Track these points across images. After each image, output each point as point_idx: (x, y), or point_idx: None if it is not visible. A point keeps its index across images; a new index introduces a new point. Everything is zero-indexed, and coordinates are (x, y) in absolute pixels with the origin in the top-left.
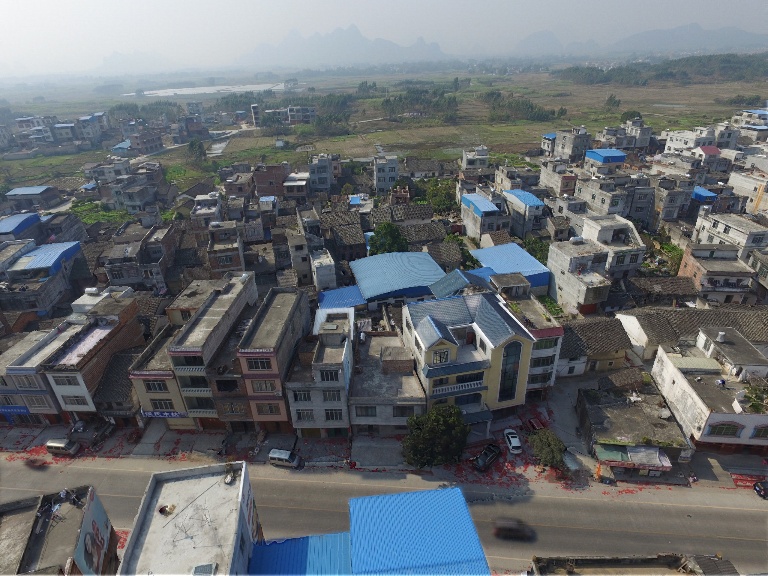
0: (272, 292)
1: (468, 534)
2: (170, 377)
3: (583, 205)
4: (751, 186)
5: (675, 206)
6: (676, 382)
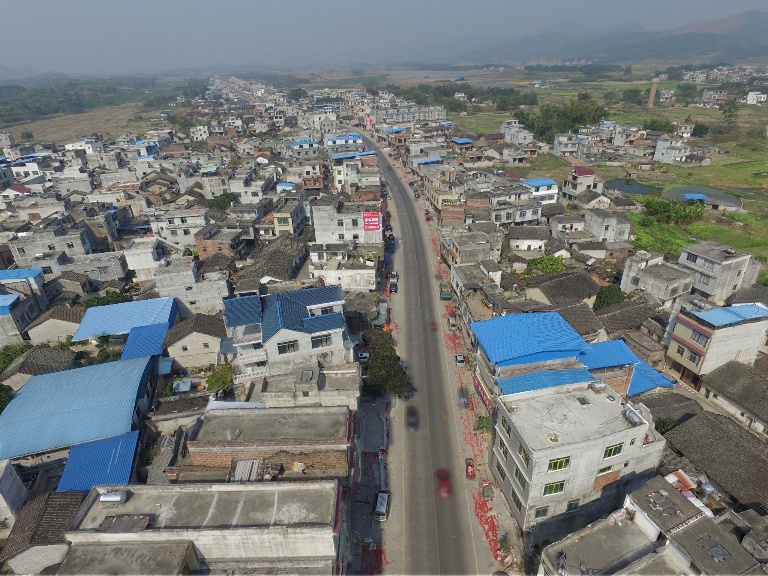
0: (194, 444)
1: (502, 318)
2: (340, 568)
3: (63, 255)
4: (113, 199)
5: (112, 227)
6: (342, 277)
